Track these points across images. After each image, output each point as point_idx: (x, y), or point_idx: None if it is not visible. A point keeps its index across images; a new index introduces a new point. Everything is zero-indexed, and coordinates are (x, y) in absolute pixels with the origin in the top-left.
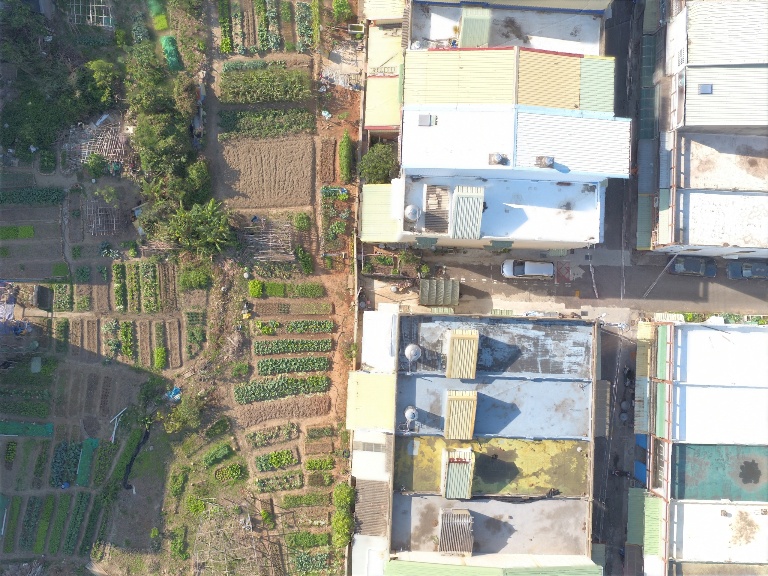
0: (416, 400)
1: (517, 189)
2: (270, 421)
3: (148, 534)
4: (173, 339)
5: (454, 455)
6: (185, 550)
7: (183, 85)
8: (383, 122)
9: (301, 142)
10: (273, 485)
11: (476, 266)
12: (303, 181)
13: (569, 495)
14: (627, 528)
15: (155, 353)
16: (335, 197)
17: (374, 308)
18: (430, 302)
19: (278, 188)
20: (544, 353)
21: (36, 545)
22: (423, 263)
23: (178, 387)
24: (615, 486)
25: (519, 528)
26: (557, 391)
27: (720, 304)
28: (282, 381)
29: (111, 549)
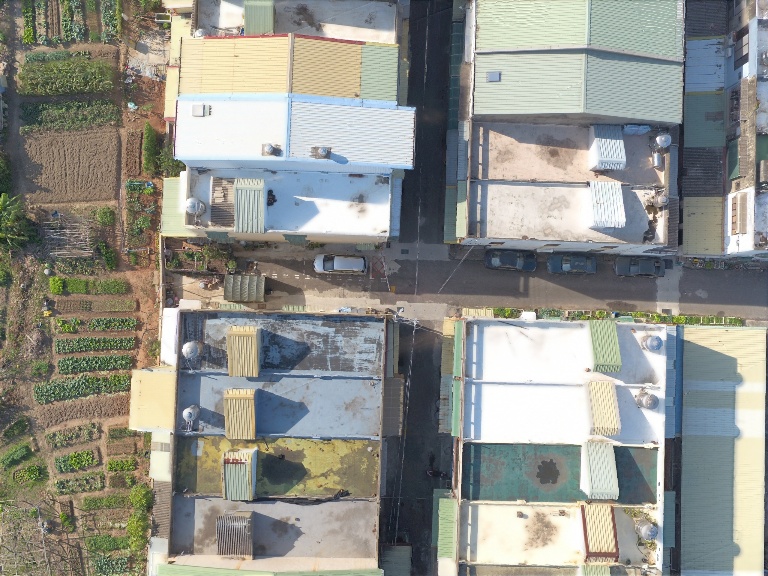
0: (200, 399)
1: (308, 181)
2: (71, 421)
3: None
4: None
5: (230, 456)
6: None
7: None
8: None
9: (106, 135)
10: (73, 487)
11: (288, 261)
12: (107, 175)
13: (358, 496)
14: (432, 530)
15: None
16: (141, 191)
17: None
18: (234, 298)
19: (81, 182)
20: (334, 350)
21: None
22: (232, 258)
23: None
24: (431, 486)
25: (306, 530)
26: (347, 389)
27: (541, 299)
28: (82, 380)
29: None
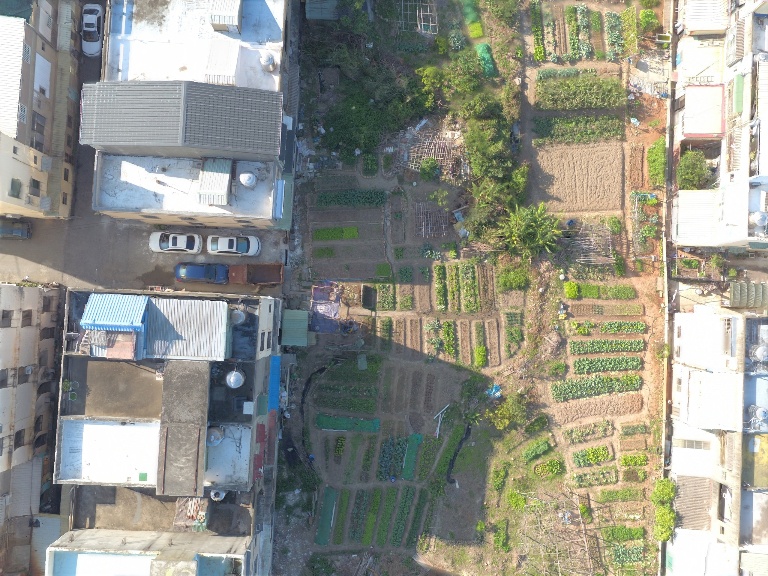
0: (756, 399)
1: None
2: (585, 418)
3: (471, 527)
4: (492, 338)
5: None
6: (507, 543)
7: (513, 92)
8: (703, 130)
9: (611, 148)
10: (590, 480)
11: None
12: (614, 186)
13: None
14: None
15: (475, 352)
16: (644, 202)
17: (679, 310)
18: (741, 304)
19: (590, 193)
20: None
21: (365, 537)
22: (726, 267)
23: (498, 385)
24: None
25: None
26: None
27: None
28: (598, 380)
29: (436, 541)
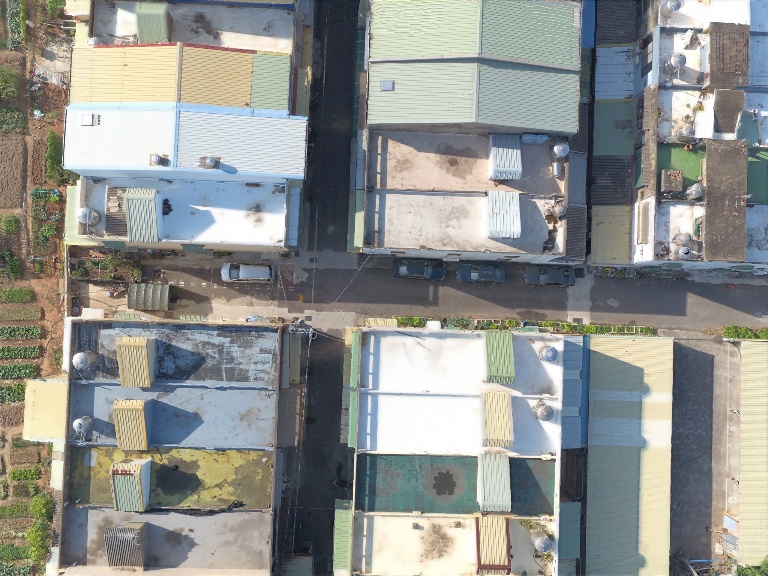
0: (94, 409)
1: (204, 190)
2: None
3: None
4: None
5: (119, 467)
6: None
7: None
8: None
9: (11, 142)
10: None
11: (196, 270)
12: (13, 183)
13: (253, 507)
14: None
15: None
16: (46, 199)
17: None
18: (138, 307)
19: None
20: (229, 360)
21: None
22: (139, 267)
23: None
24: (338, 496)
25: (200, 541)
26: (242, 400)
27: (451, 308)
28: None
29: None
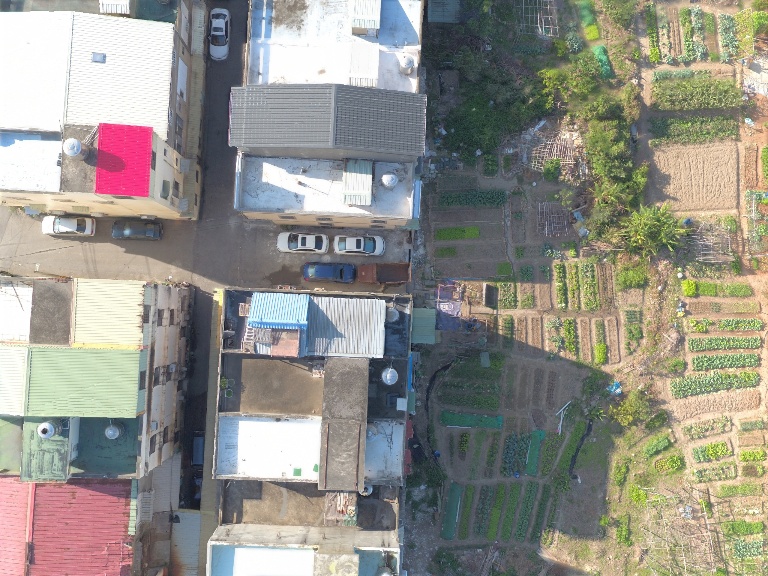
0: None
1: None
2: (704, 414)
3: (593, 522)
4: (612, 336)
5: None
6: (629, 537)
7: (634, 93)
8: None
9: (726, 148)
10: (709, 476)
11: None
12: (729, 185)
13: None
14: None
15: (596, 349)
16: (759, 201)
17: None
18: None
19: (706, 192)
20: None
21: (489, 532)
22: None
23: (618, 382)
24: None
25: None
26: None
27: None
28: (717, 376)
29: (559, 536)
